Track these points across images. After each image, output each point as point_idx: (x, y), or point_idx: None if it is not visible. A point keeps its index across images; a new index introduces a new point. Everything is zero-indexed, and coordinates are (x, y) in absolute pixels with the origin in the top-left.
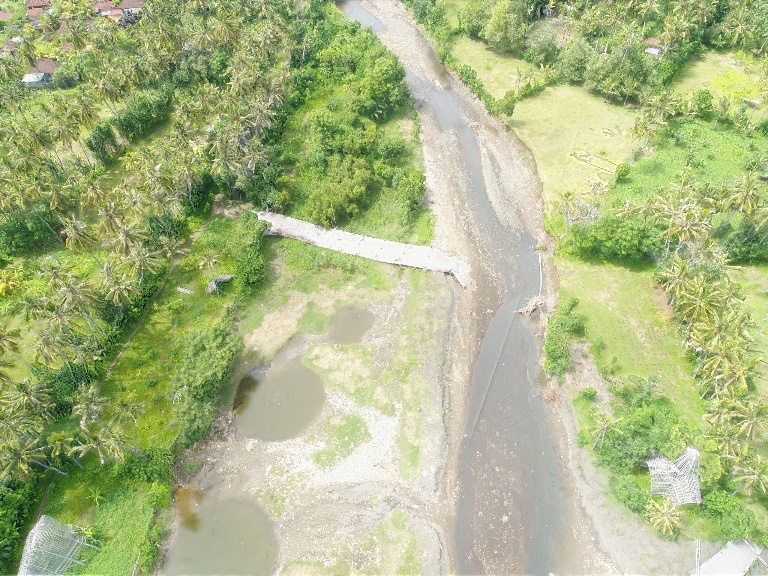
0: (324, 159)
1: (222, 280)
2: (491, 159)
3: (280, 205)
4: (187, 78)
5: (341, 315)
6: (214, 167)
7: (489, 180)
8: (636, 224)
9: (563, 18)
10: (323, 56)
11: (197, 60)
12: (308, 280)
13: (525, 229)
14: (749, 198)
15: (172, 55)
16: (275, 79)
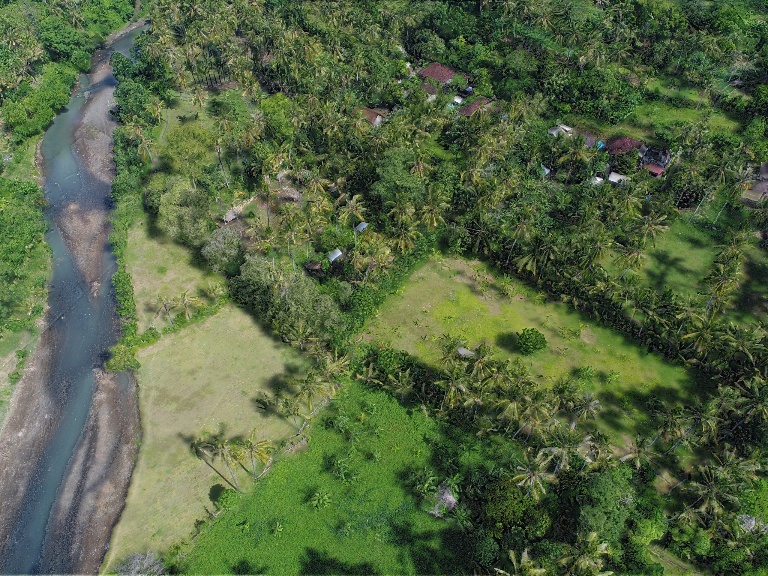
0: None
1: None
2: (91, 440)
3: None
4: None
5: None
6: None
7: (66, 485)
8: None
9: (297, 188)
10: None
11: None
12: None
13: None
14: None
15: None
16: None
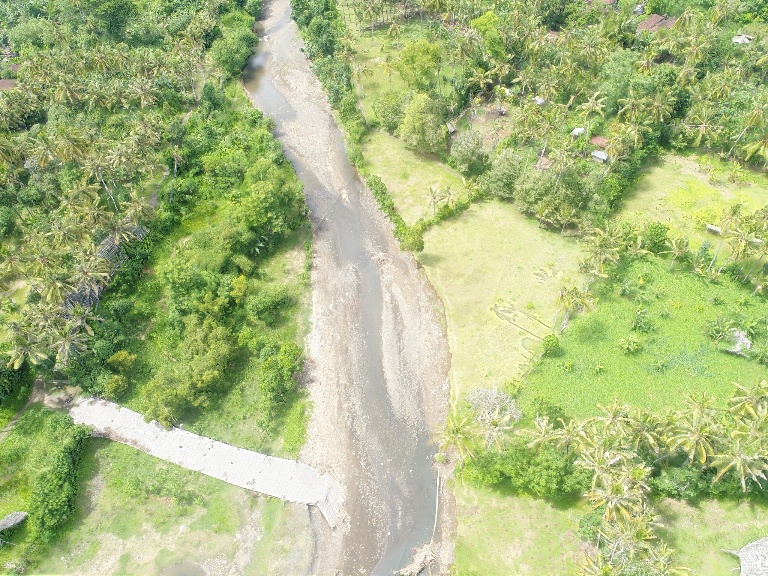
0: (179, 320)
1: (6, 527)
2: (394, 311)
3: (112, 393)
4: (38, 195)
5: (164, 575)
6: (11, 359)
7: (388, 344)
8: (553, 461)
9: None
10: (204, 165)
11: (43, 178)
12: (130, 515)
13: (424, 426)
14: (702, 442)
15: (7, 176)
16: (126, 211)
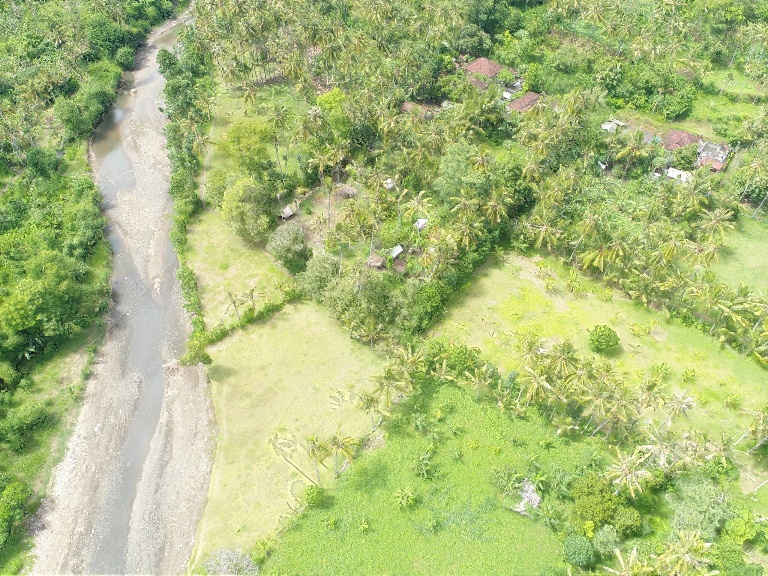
0: None
1: None
2: (167, 436)
3: None
4: None
5: None
6: None
7: (146, 480)
8: None
9: (351, 184)
10: None
11: None
12: None
13: None
14: None
15: None
16: None
